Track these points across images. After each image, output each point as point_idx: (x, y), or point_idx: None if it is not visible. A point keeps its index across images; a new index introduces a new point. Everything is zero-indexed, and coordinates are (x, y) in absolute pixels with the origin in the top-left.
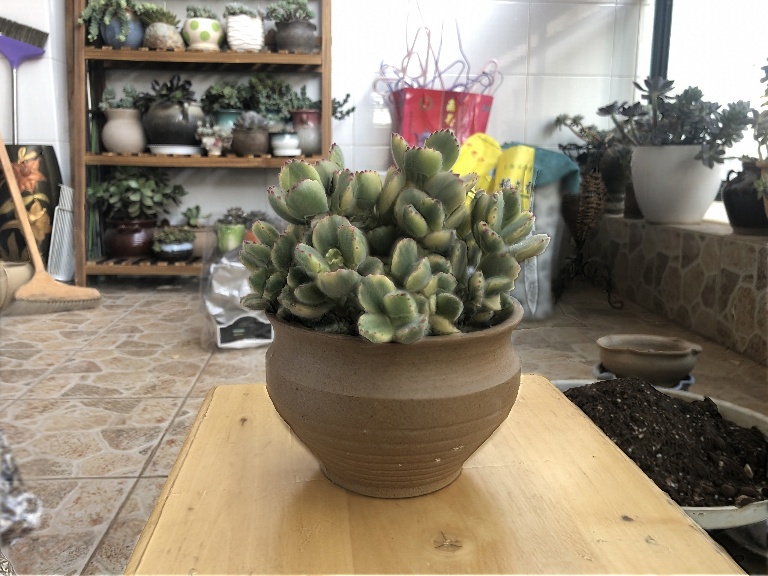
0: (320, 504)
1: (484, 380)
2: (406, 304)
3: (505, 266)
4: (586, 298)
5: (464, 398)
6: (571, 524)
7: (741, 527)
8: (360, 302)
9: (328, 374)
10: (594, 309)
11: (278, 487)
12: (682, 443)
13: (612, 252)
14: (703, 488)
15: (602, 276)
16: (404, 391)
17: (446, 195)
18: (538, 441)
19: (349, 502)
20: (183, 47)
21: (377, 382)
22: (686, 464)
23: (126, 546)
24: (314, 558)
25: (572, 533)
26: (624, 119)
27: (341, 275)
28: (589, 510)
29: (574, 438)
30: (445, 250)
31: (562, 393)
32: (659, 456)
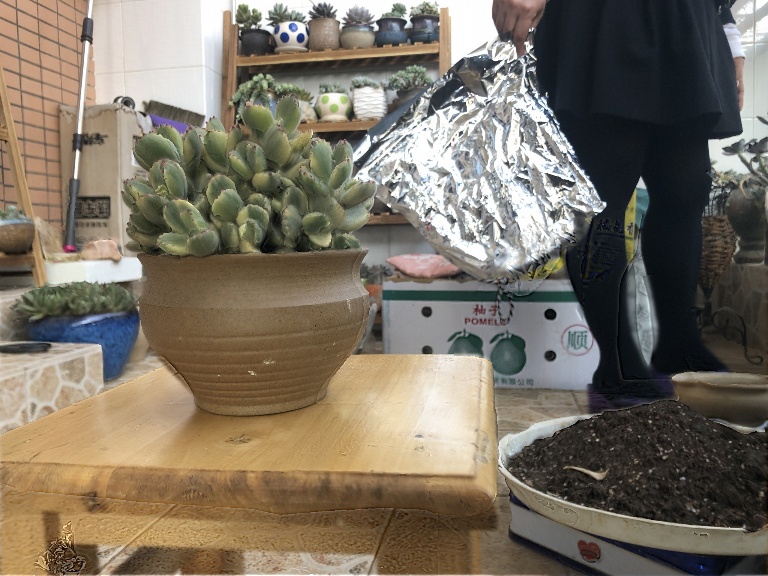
0: (169, 415)
1: (287, 299)
2: (189, 218)
3: (325, 205)
4: (723, 353)
5: (261, 311)
6: (361, 436)
7: (766, 560)
8: (167, 223)
9: (158, 291)
10: (727, 364)
11: (151, 406)
12: (711, 467)
13: (754, 303)
14: (728, 515)
15: (735, 327)
16: (207, 302)
17: (271, 144)
18: (410, 392)
19: (194, 416)
20: (315, 120)
21: (188, 295)
22: (712, 489)
23: (168, 532)
24: (123, 440)
25: (353, 441)
26: (751, 157)
27: (148, 199)
28: (391, 430)
29: (447, 391)
30: (266, 190)
31: (490, 370)
32: (682, 479)
